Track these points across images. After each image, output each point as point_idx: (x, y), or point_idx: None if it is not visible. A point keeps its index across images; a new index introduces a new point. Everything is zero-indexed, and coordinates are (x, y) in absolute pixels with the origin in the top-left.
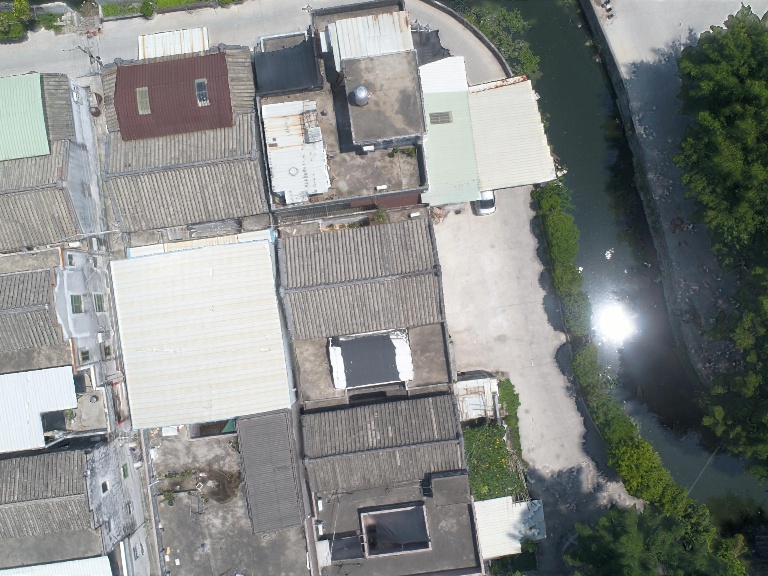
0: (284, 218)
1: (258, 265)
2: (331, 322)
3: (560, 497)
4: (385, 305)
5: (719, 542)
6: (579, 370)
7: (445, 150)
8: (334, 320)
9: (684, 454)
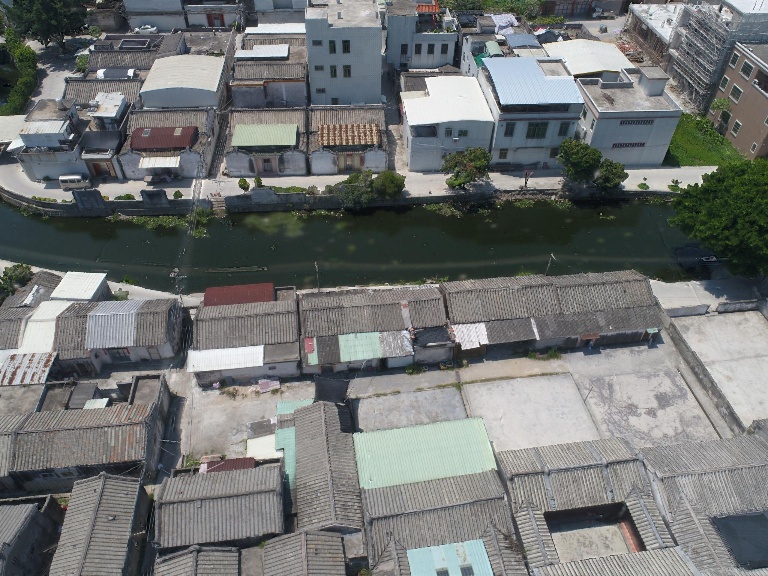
0: None
1: None
2: None
3: (68, 66)
4: None
5: (9, 42)
6: None
7: None
8: None
9: (7, 78)
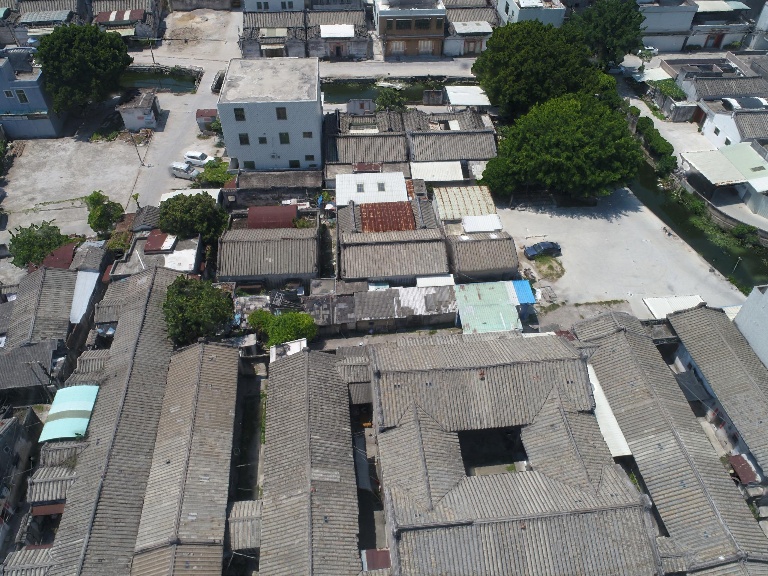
0: None
1: None
2: None
3: None
4: None
5: None
6: None
7: (749, 159)
8: None
9: None
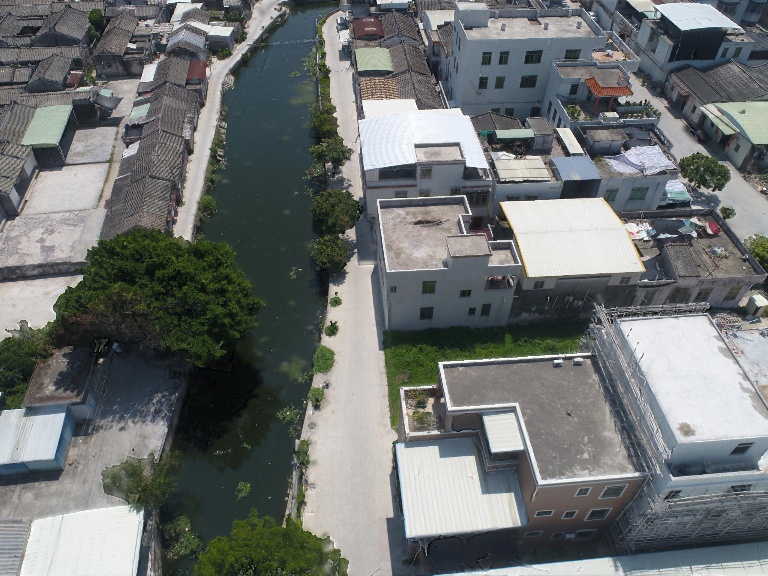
0: (414, 19)
1: None
2: (453, 8)
3: None
4: None
5: None
6: None
7: None
8: (452, 7)
9: None
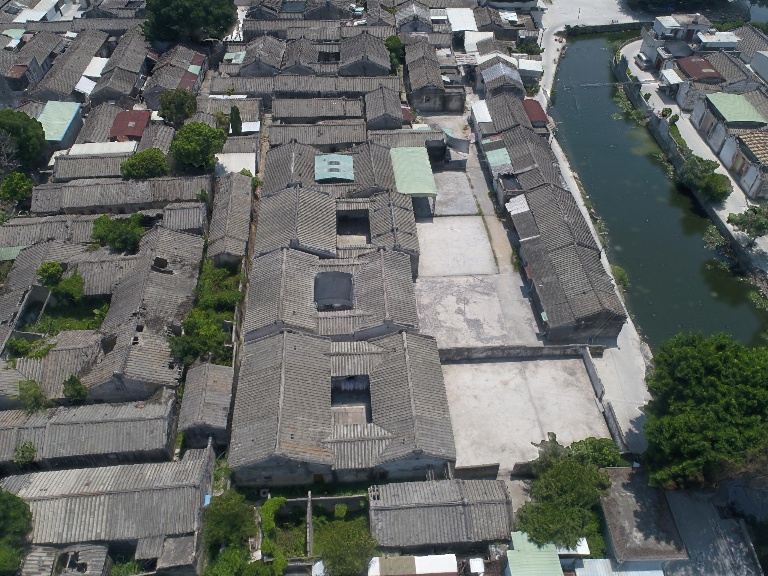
0: None
1: (767, 52)
2: None
3: None
4: (766, 38)
5: None
6: (762, 25)
7: None
8: None
9: None
